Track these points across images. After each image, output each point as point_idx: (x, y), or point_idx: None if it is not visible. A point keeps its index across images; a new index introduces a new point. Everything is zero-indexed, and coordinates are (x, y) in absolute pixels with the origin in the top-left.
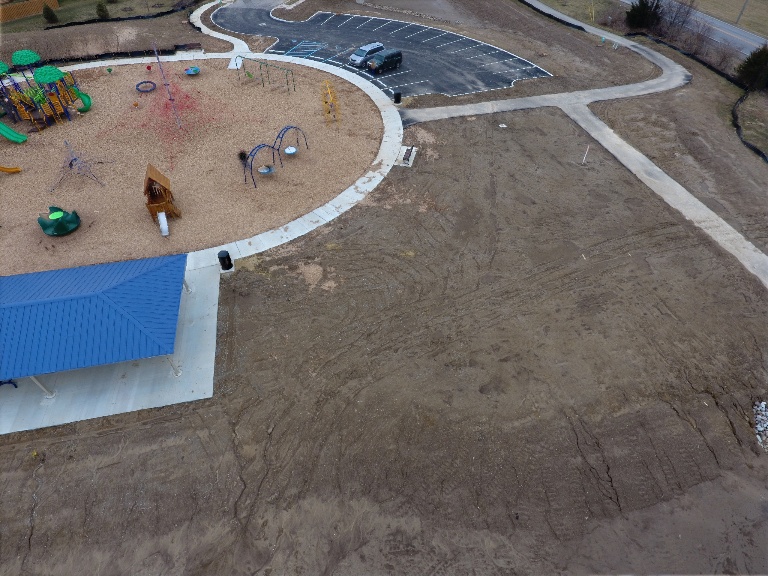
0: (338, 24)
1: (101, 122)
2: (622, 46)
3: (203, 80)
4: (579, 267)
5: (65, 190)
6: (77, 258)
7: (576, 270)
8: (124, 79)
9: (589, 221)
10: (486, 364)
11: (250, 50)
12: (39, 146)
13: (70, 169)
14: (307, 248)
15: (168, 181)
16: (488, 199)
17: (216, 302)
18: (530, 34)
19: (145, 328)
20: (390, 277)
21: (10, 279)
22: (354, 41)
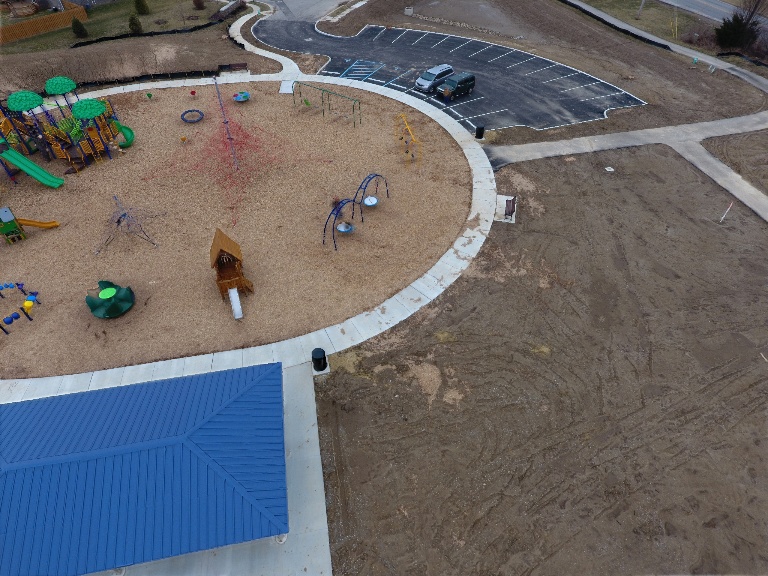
0: (391, 40)
1: (146, 161)
2: (718, 69)
3: (254, 108)
4: (763, 373)
5: (113, 252)
6: (135, 350)
7: (761, 378)
8: (166, 106)
9: (754, 304)
10: (689, 531)
11: (301, 71)
12: (78, 192)
13: (118, 226)
14: (414, 339)
15: (239, 248)
16: (620, 270)
17: (315, 421)
18: (606, 52)
19: (248, 492)
20: (527, 385)
21: (62, 402)
22: (413, 60)
